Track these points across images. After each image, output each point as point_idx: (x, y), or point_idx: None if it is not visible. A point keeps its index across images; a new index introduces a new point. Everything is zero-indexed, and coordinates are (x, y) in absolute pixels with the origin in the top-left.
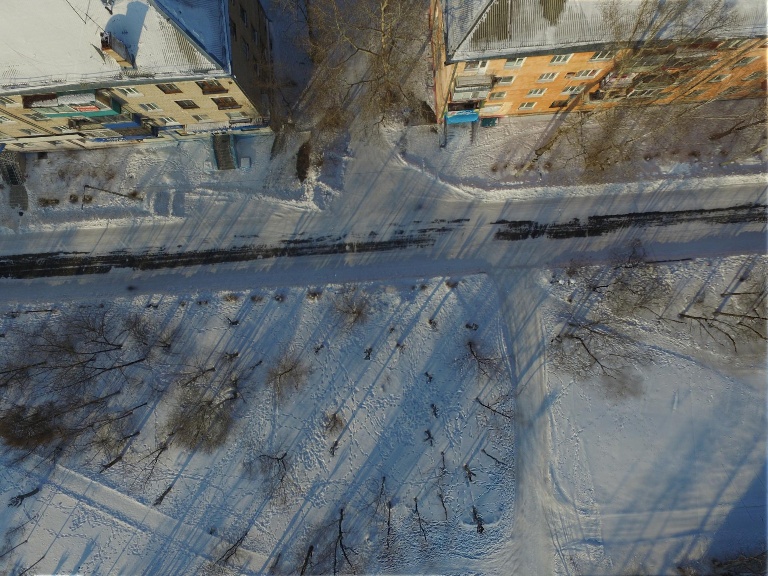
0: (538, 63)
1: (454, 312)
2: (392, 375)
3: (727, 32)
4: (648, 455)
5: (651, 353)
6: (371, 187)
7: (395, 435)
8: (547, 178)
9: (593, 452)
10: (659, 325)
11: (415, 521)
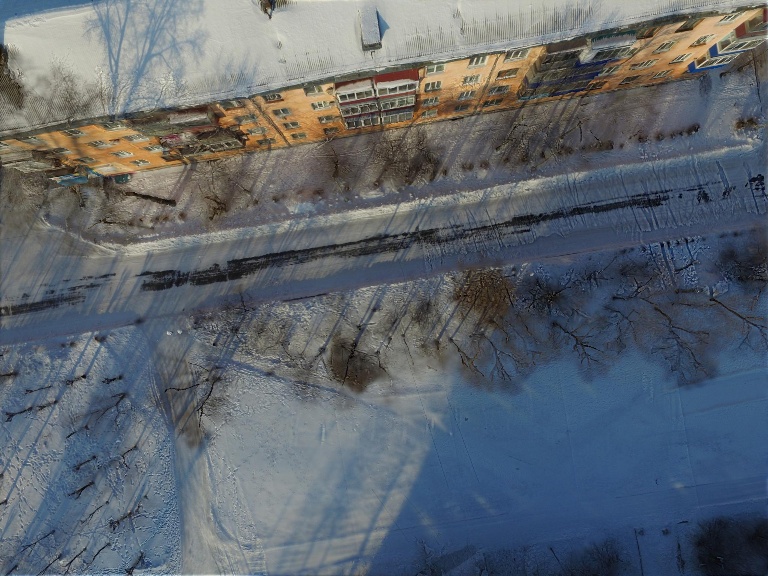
0: (56, 138)
1: (107, 365)
2: (53, 431)
3: (189, 100)
4: (302, 487)
5: (296, 388)
6: (18, 251)
7: (61, 489)
8: (182, 228)
9: (250, 489)
10: (301, 360)
11: (87, 570)
